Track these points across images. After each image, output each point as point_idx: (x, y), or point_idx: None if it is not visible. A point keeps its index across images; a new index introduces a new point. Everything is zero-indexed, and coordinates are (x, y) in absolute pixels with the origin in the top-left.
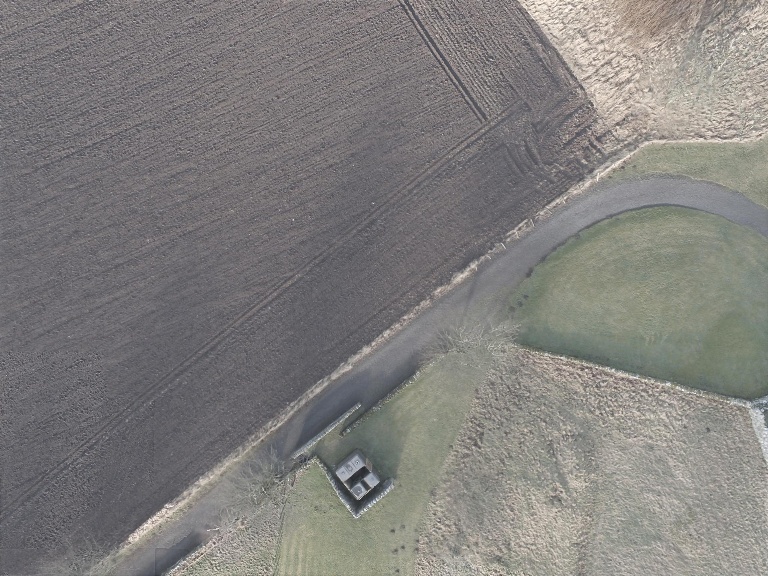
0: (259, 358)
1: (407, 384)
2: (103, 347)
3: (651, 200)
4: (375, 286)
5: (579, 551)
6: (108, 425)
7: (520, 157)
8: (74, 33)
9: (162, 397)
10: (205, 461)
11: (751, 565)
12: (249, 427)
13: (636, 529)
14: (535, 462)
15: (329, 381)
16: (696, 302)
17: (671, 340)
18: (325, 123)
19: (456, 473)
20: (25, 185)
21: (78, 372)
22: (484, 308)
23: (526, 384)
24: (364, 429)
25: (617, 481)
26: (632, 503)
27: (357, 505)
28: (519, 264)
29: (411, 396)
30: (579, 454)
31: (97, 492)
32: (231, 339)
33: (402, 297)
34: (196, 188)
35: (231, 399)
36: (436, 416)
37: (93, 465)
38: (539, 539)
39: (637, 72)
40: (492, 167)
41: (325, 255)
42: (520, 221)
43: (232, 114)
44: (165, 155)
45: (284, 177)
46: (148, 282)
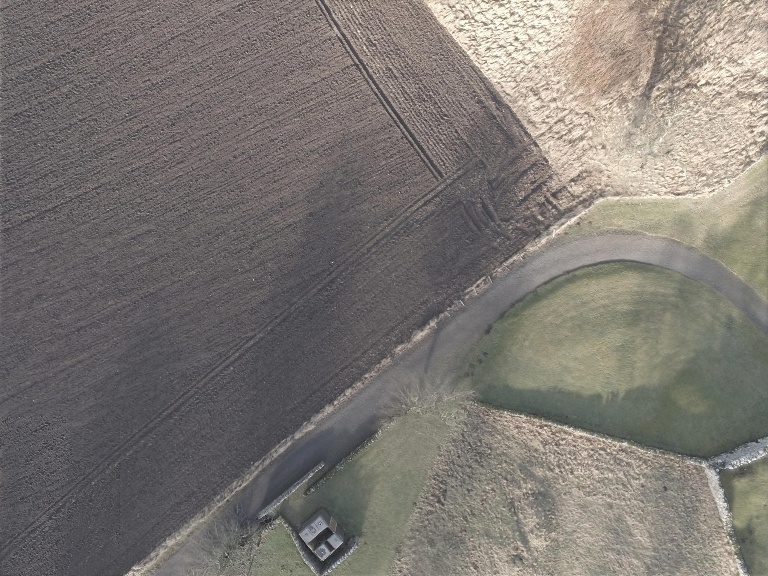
0: (223, 418)
1: (369, 443)
2: (67, 410)
3: (607, 256)
4: (336, 345)
5: None
6: (74, 488)
7: (477, 214)
8: (32, 97)
9: (127, 459)
10: (171, 522)
11: None
12: (214, 487)
13: None
14: (497, 520)
15: (292, 440)
16: (652, 359)
17: (628, 398)
18: (283, 183)
19: (420, 530)
20: None
21: (43, 436)
22: (444, 365)
23: (487, 441)
24: (328, 488)
25: (578, 539)
26: (592, 561)
27: (322, 565)
28: (478, 321)
29: (374, 454)
30: (539, 513)
31: (65, 555)
32: (194, 400)
33: (363, 355)
34: (156, 250)
35: (196, 460)
36: (399, 474)
37: (60, 528)
38: None
39: (590, 129)
40: (449, 225)
41: (286, 314)
42: (478, 278)
43: (190, 175)
44: (125, 217)
45: (243, 237)
46: (111, 345)
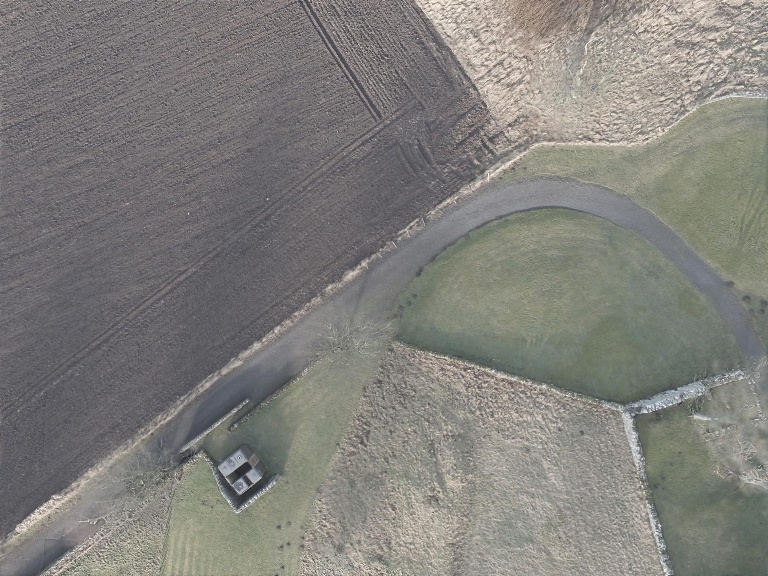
0: (151, 351)
1: (295, 381)
2: None
3: (540, 202)
4: (267, 282)
5: (455, 551)
6: None
7: (413, 156)
8: None
9: (54, 388)
10: (95, 453)
11: (617, 569)
12: (139, 420)
13: (510, 531)
14: (417, 461)
15: (219, 376)
16: (577, 305)
17: (551, 342)
18: (222, 118)
19: (342, 471)
20: None
21: None
22: (374, 306)
23: (412, 383)
24: (252, 425)
25: (495, 482)
26: (508, 504)
27: (241, 500)
28: (409, 263)
29: (299, 393)
30: (457, 454)
31: None
32: (124, 332)
33: (294, 293)
34: (93, 180)
35: (122, 392)
36: (324, 413)
37: None
38: (417, 538)
39: (528, 73)
40: (385, 165)
41: (219, 250)
42: (411, 220)
43: (131, 107)
44: (64, 146)
45: (180, 171)
46: (43, 273)
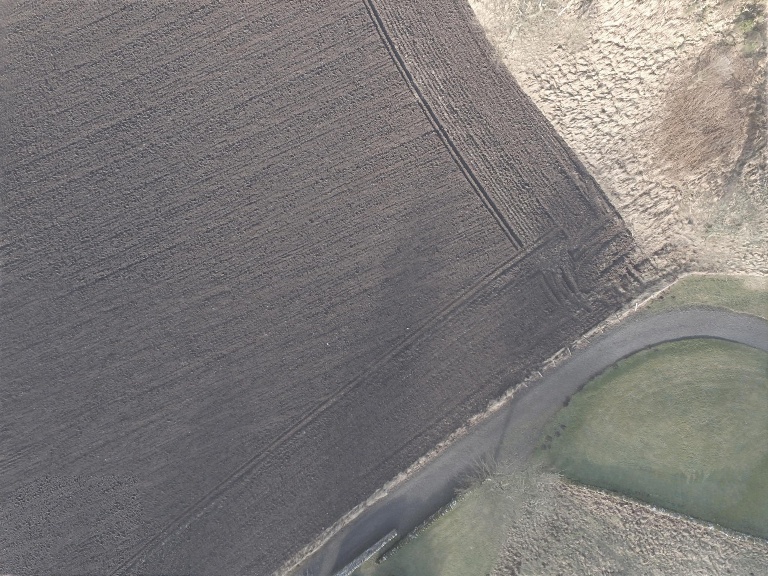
0: (294, 483)
1: (444, 513)
2: (139, 470)
3: (691, 331)
4: (410, 412)
5: None
6: (144, 548)
7: (556, 285)
8: (108, 155)
9: (198, 521)
10: None
11: None
12: (285, 552)
13: None
14: None
15: (365, 507)
16: (738, 441)
17: (713, 479)
18: (359, 248)
19: None
20: (61, 308)
21: (114, 495)
22: (521, 436)
23: (564, 515)
24: (400, 556)
25: None
26: None
27: None
28: (556, 393)
29: (447, 524)
30: None
31: None
32: (266, 463)
33: (438, 423)
34: (230, 311)
35: (267, 523)
36: (473, 544)
37: None
38: None
39: (676, 204)
40: (528, 294)
41: (360, 380)
42: (557, 349)
43: (266, 238)
44: (199, 278)
45: (318, 301)
46: (183, 405)
